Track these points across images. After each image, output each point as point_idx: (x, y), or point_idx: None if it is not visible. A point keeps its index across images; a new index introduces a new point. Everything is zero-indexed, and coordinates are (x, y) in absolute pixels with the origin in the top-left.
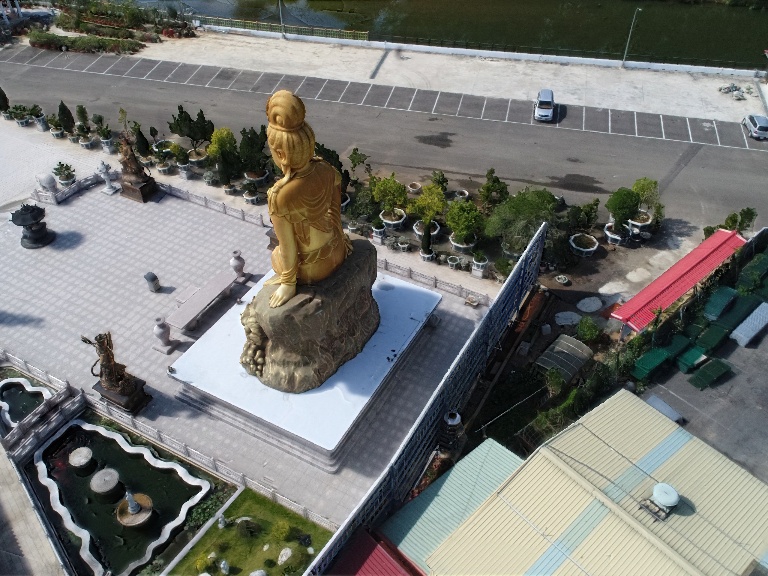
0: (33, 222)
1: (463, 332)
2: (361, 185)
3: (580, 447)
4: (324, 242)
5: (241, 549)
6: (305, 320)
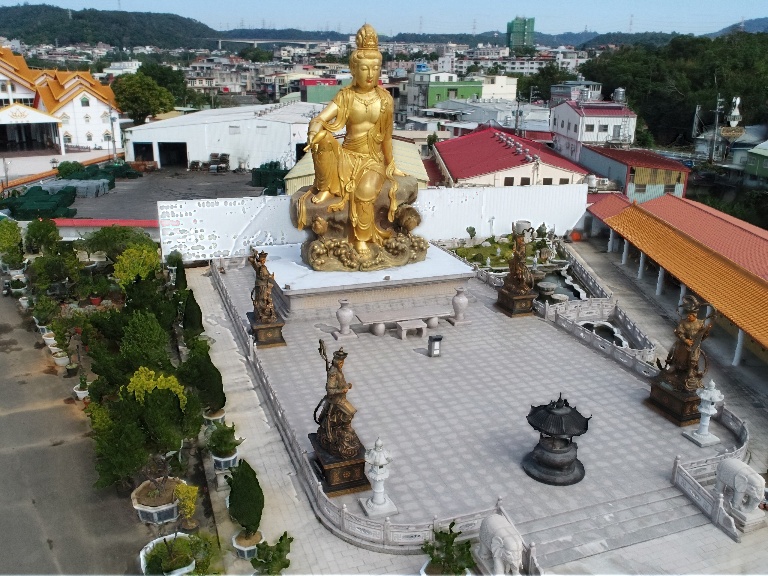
0: None
1: None
2: None
3: None
4: None
5: (486, 258)
6: None
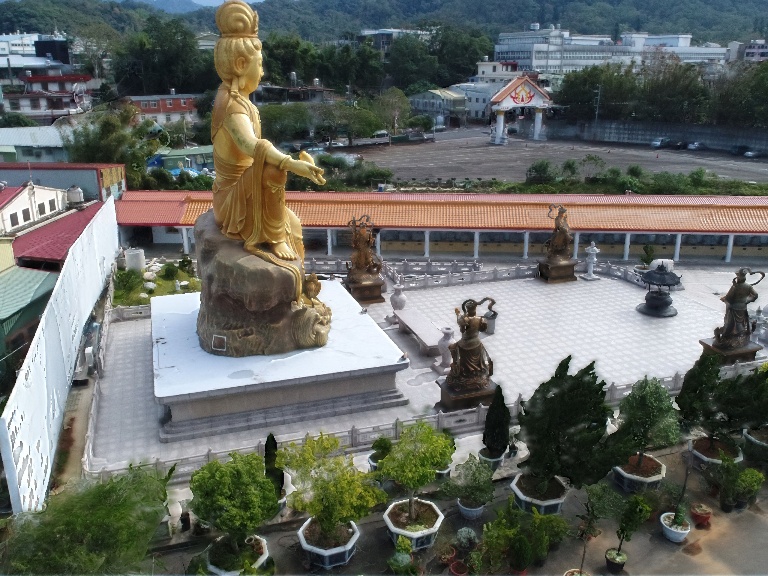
0: None
1: (118, 445)
2: (556, 525)
3: None
4: None
5: None
6: None
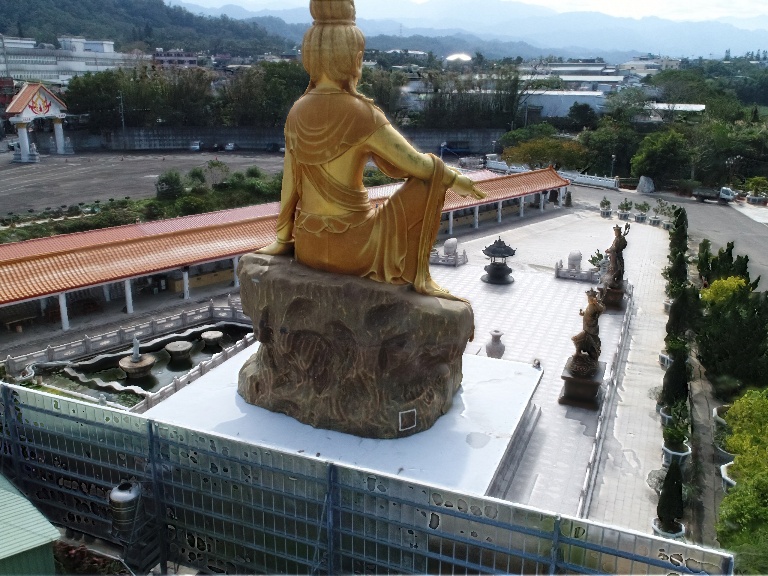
0: (490, 253)
1: None
2: None
3: None
4: (320, 210)
5: None
6: (244, 278)
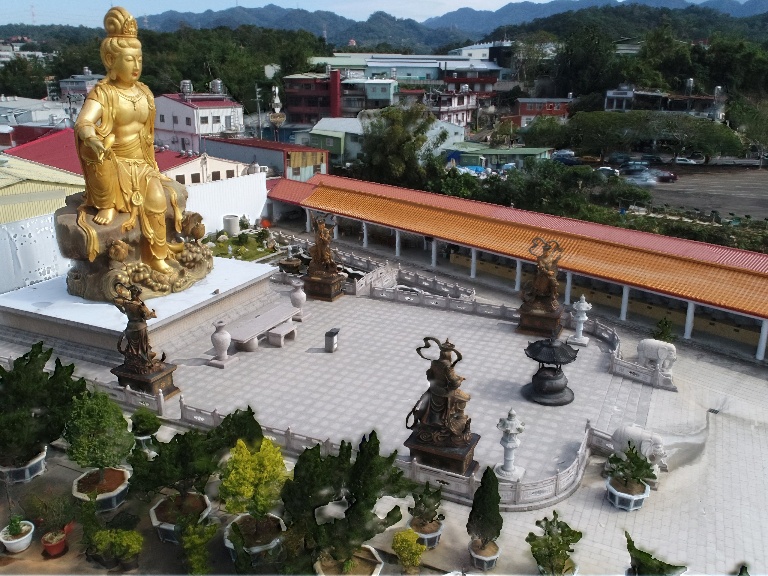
0: None
1: None
2: None
3: (1, 183)
4: None
5: None
6: None
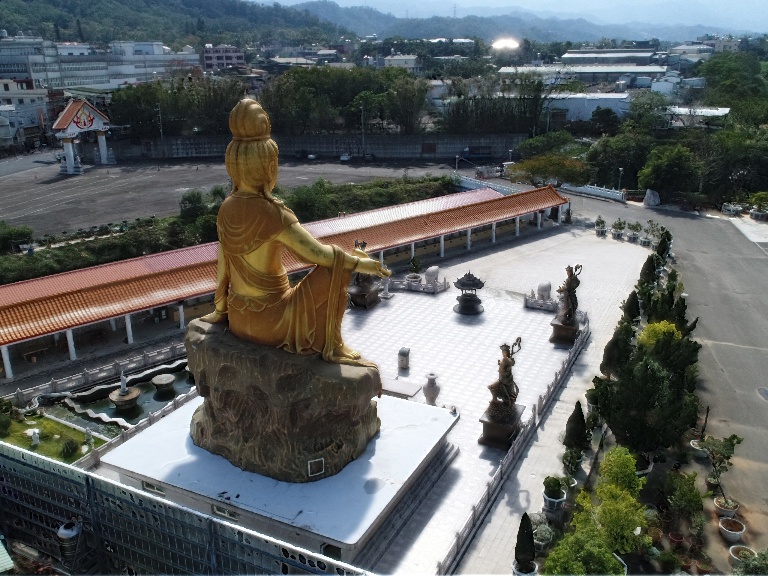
0: (459, 286)
1: None
2: None
3: None
4: (243, 292)
5: (53, 450)
6: None
